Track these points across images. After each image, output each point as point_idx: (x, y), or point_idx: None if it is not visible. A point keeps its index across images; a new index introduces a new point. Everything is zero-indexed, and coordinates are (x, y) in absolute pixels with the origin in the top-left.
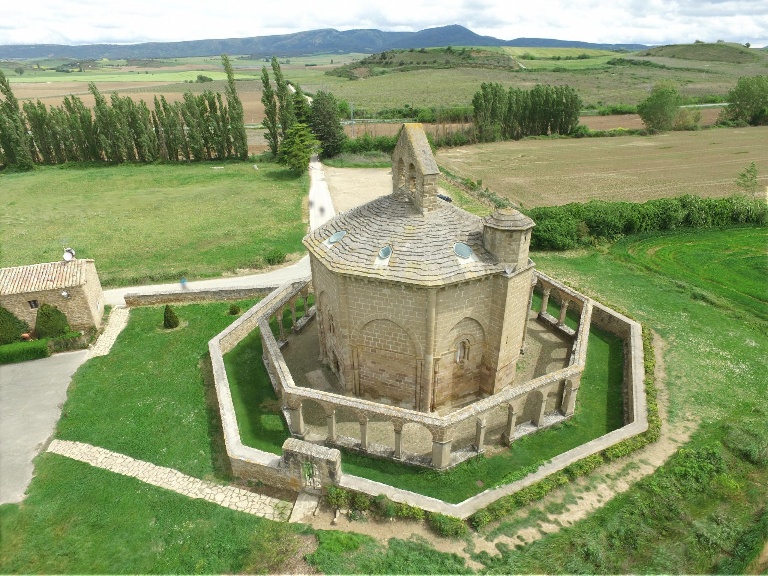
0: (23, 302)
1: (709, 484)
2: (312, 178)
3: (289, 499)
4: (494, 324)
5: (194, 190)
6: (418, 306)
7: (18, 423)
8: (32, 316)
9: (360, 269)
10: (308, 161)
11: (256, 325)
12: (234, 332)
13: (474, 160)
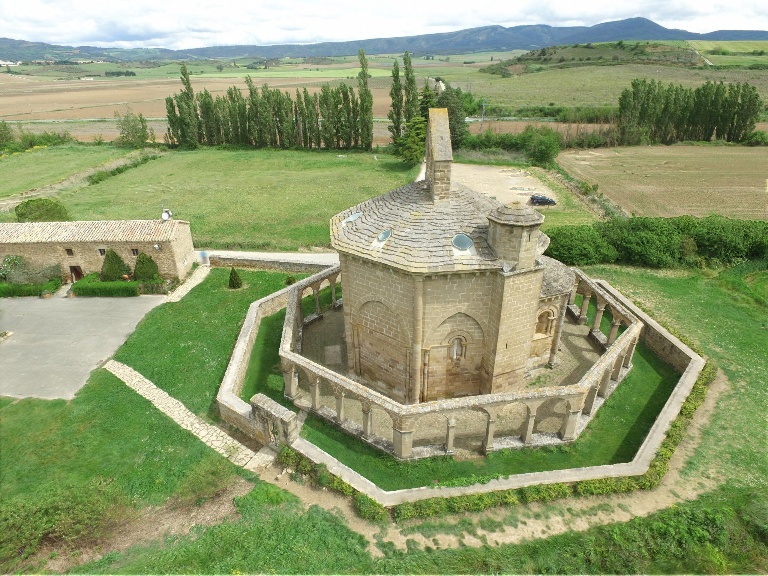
0: (128, 249)
1: (695, 553)
2: (422, 171)
3: (254, 449)
4: (492, 325)
5: (312, 174)
6: (406, 292)
7: (95, 342)
8: (134, 262)
9: (357, 248)
10: (421, 154)
11: (302, 297)
12: (277, 299)
13: (604, 164)
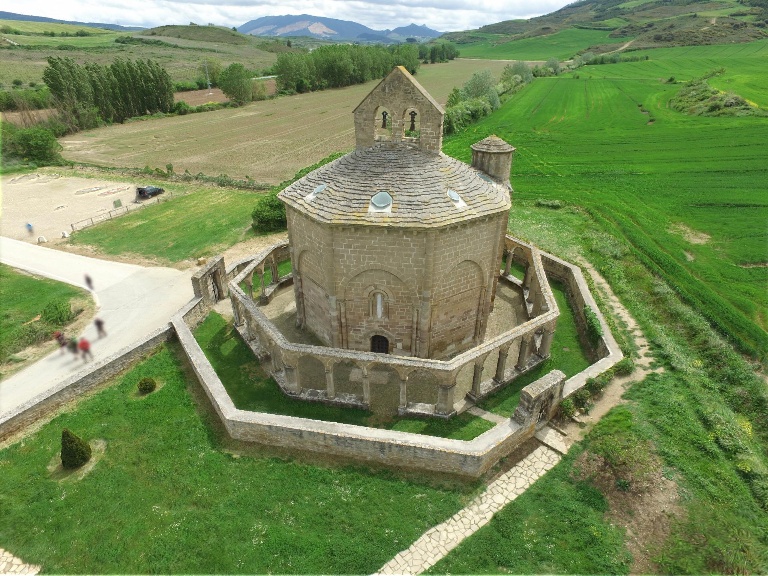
0: None
1: None
2: None
3: (535, 446)
4: None
5: None
6: (490, 235)
7: None
8: None
9: (454, 216)
10: None
11: None
12: None
13: (108, 149)
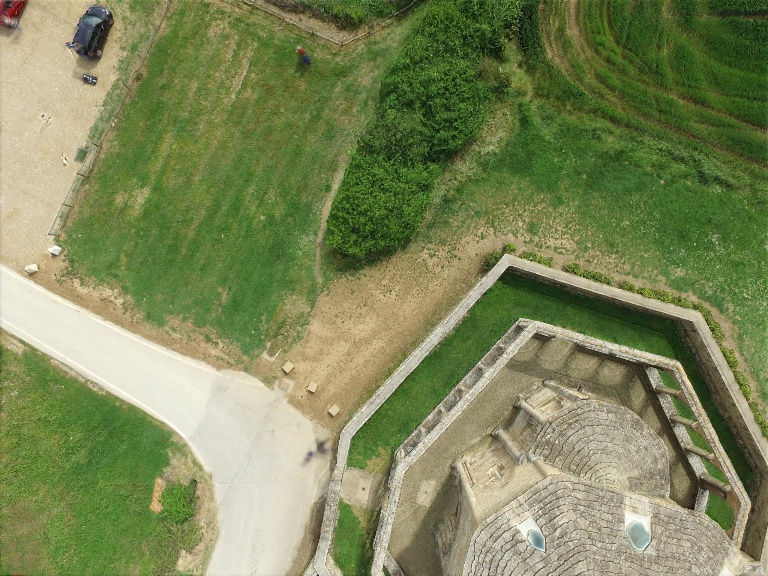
0: None
1: None
2: None
3: None
4: None
5: None
6: None
7: None
8: None
9: None
10: None
11: None
12: None
13: None
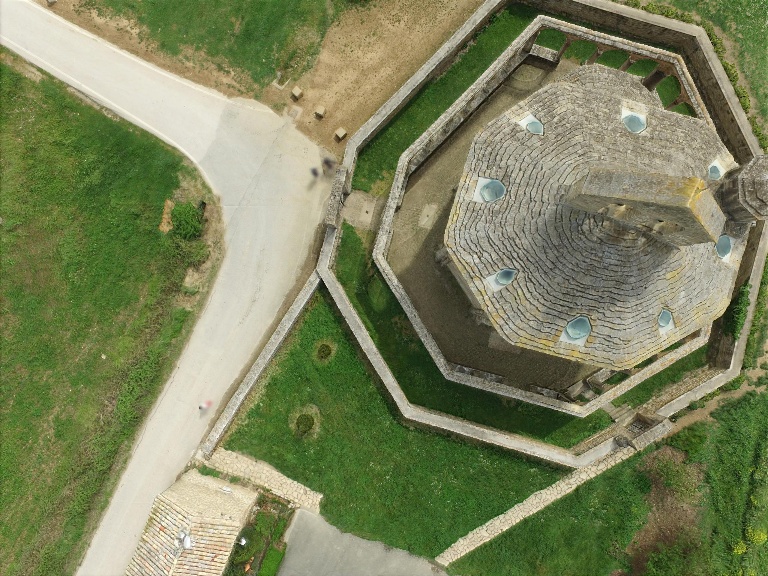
0: None
1: None
2: None
3: None
4: None
5: None
6: None
7: None
8: (225, 564)
9: None
10: None
11: None
12: None
13: None
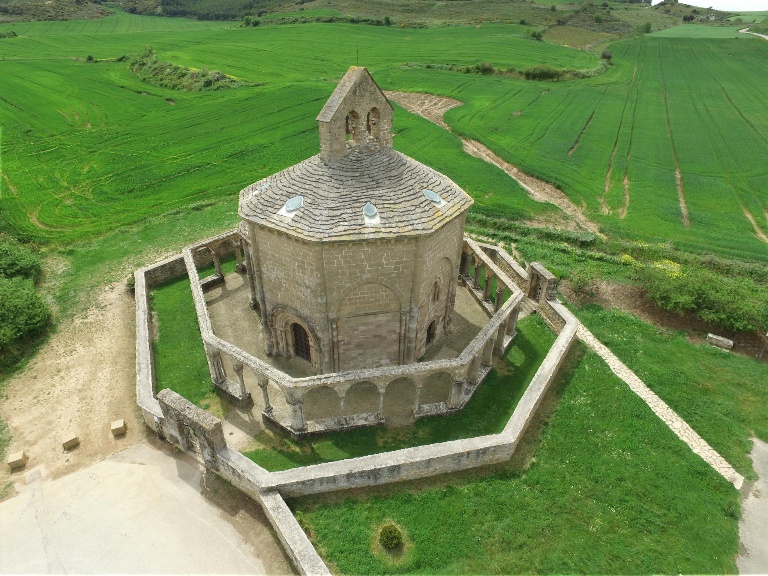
0: None
1: None
2: None
3: None
4: None
5: None
6: None
7: None
8: None
9: None
10: None
11: None
12: None
13: None
